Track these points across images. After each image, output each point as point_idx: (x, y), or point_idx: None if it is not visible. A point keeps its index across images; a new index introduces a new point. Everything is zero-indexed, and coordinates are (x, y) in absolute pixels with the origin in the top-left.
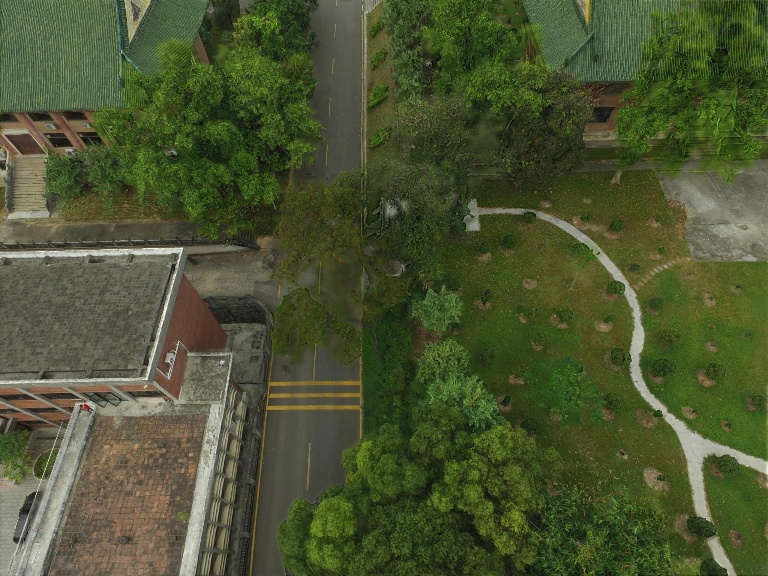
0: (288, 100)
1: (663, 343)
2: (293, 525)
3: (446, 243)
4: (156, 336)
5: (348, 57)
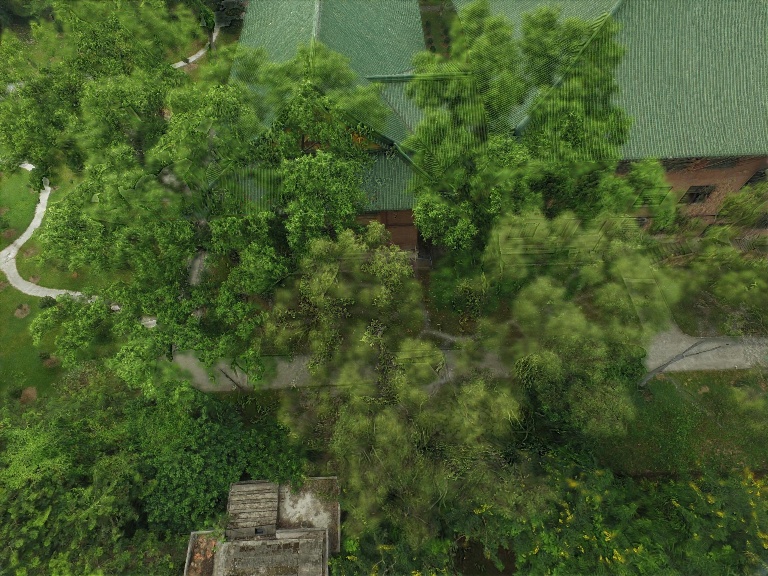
0: None
1: None
2: None
3: None
4: None
5: None
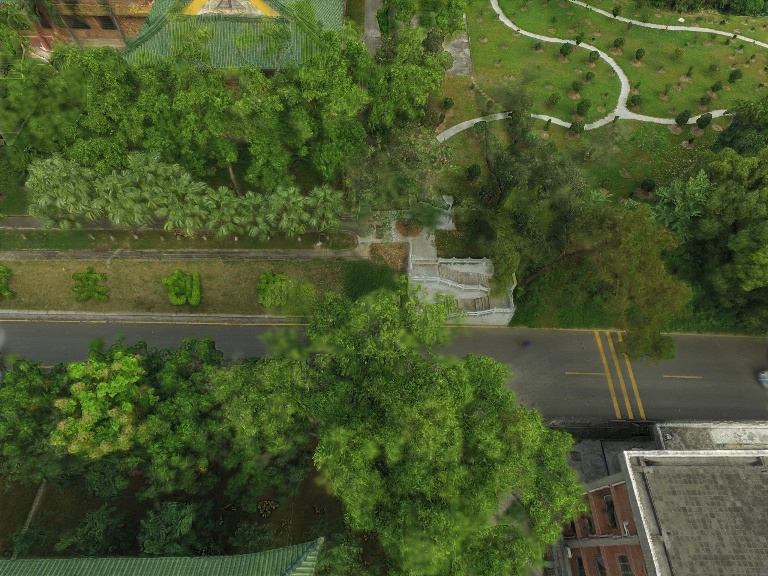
0: (353, 319)
1: (553, 107)
2: None
3: (470, 224)
4: (759, 454)
5: (36, 343)
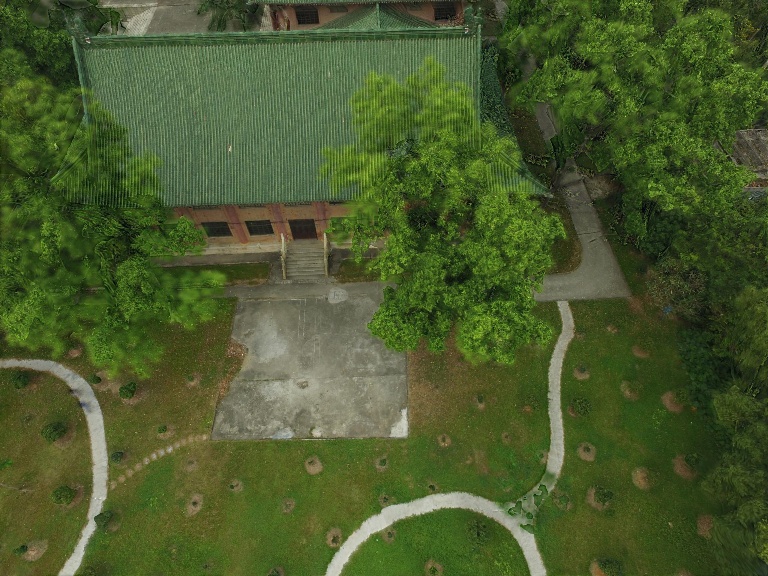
0: None
1: None
2: None
3: None
4: None
5: None
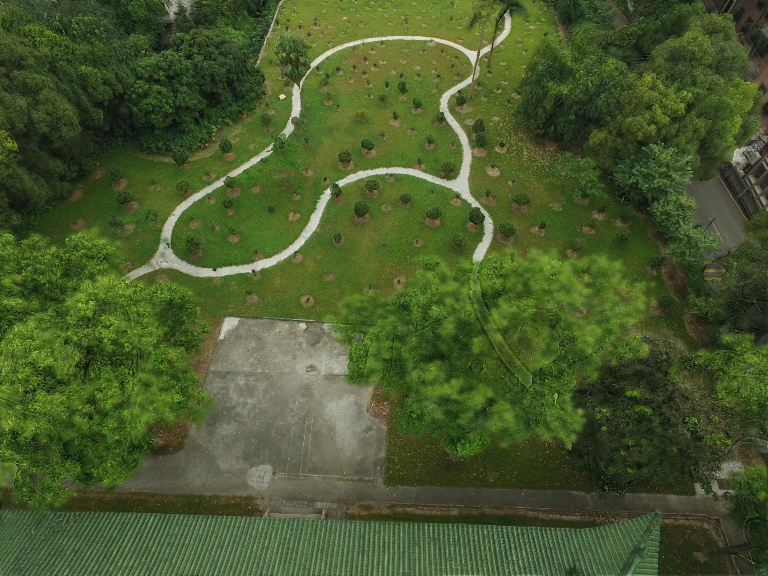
0: None
1: None
2: (761, 104)
3: None
4: None
5: None
